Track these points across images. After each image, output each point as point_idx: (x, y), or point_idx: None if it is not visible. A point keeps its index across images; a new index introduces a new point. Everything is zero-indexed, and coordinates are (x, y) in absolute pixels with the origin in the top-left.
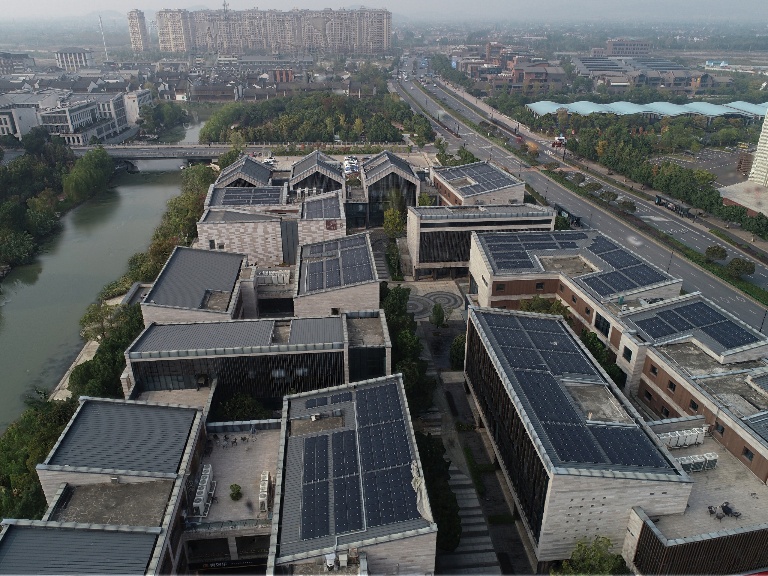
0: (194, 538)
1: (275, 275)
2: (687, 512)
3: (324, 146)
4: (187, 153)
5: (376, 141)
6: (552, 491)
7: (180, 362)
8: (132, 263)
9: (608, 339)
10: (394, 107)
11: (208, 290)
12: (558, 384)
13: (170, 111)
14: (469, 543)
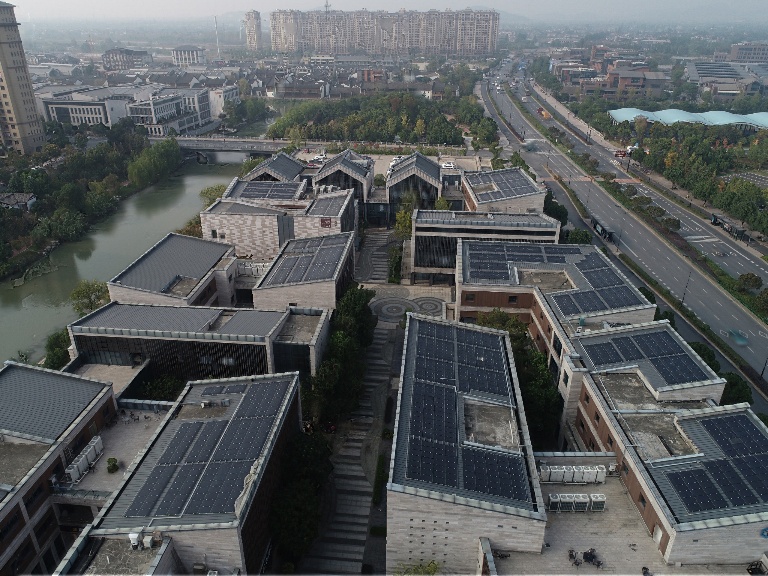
0: (61, 502)
1: (255, 267)
2: (546, 552)
3: (377, 146)
4: (250, 147)
5: (435, 143)
6: (389, 507)
7: (116, 340)
8: None
9: (560, 361)
10: (465, 109)
11: (179, 276)
12: (457, 400)
13: (252, 107)
14: (341, 550)
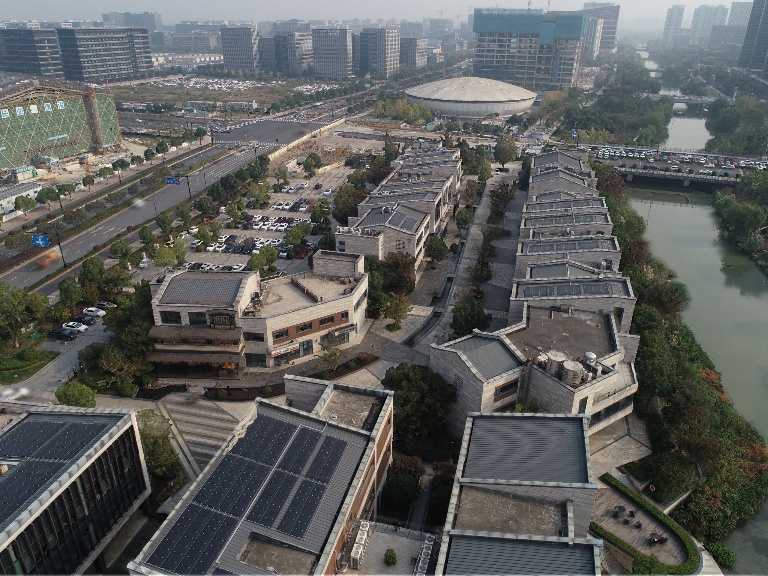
0: None
1: None
2: None
3: None
4: None
5: None
6: None
7: None
8: None
9: None
10: None
11: None
12: None
13: None
14: None
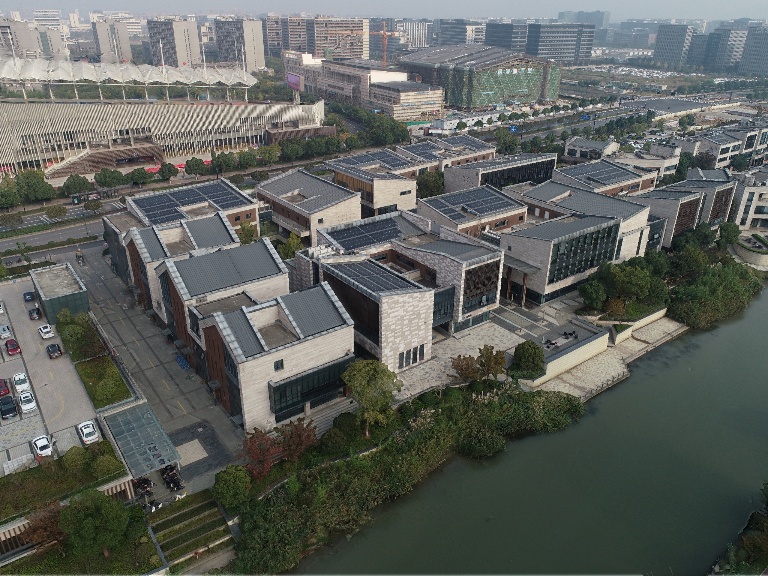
0: None
1: (497, 233)
2: None
3: None
4: None
5: None
6: None
7: None
8: None
9: None
10: None
11: None
12: None
13: None
14: None
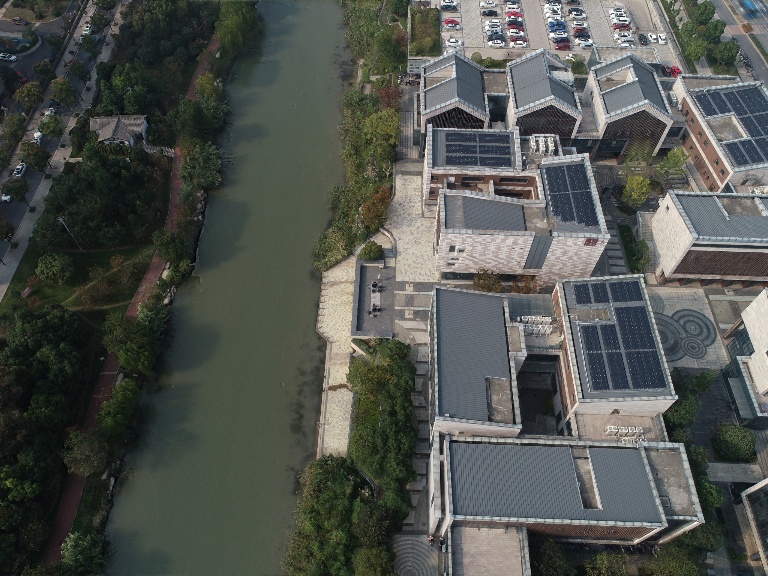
0: None
1: (537, 327)
2: None
3: None
4: None
5: None
6: None
7: None
8: (334, 204)
9: None
10: None
11: (487, 377)
12: None
13: None
14: None
